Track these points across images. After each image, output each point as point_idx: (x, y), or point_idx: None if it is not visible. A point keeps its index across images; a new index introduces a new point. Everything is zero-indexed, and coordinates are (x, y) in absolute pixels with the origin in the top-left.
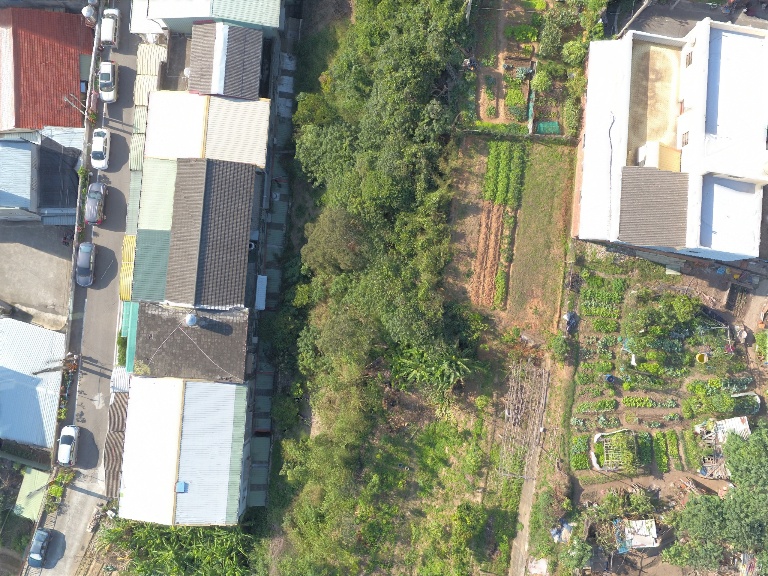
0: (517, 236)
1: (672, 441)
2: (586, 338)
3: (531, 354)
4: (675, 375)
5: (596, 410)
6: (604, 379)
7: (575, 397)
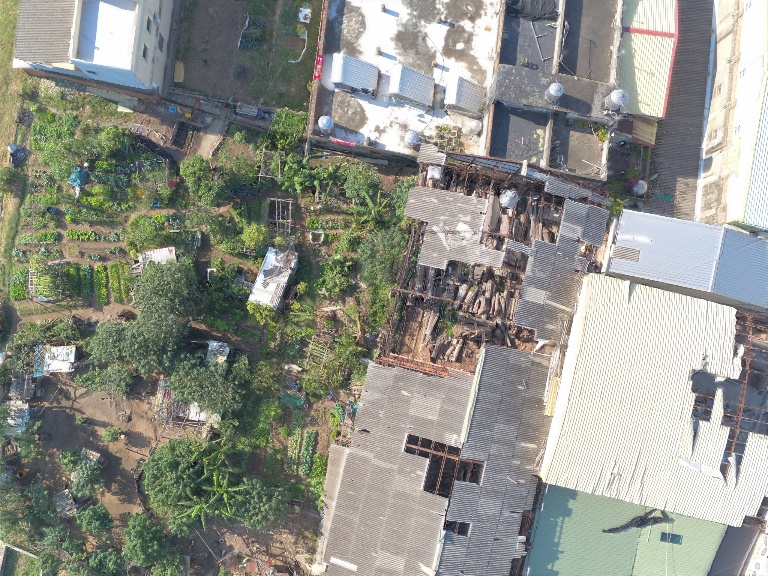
0: None
1: (113, 274)
2: (34, 171)
3: None
4: (119, 209)
5: (37, 241)
6: (39, 208)
7: (19, 229)
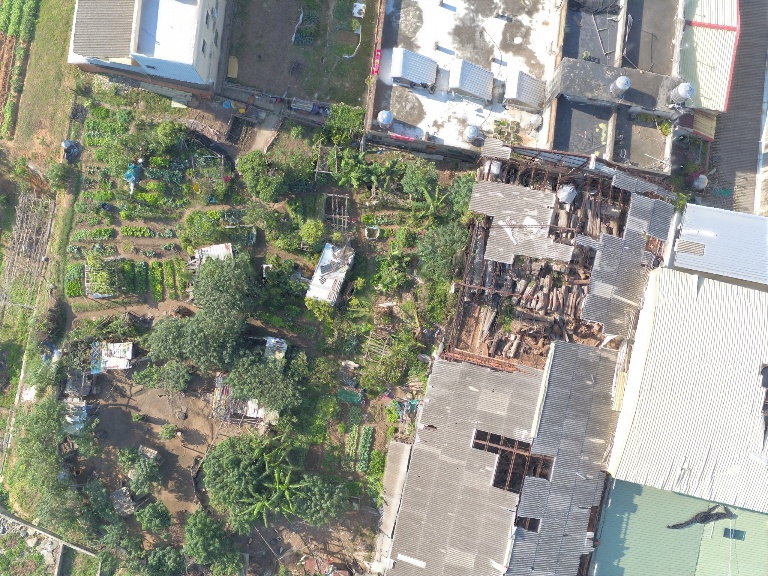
0: (28, 68)
1: (168, 270)
2: (87, 167)
3: (51, 189)
4: (174, 205)
5: (92, 238)
6: (94, 205)
7: (73, 225)
